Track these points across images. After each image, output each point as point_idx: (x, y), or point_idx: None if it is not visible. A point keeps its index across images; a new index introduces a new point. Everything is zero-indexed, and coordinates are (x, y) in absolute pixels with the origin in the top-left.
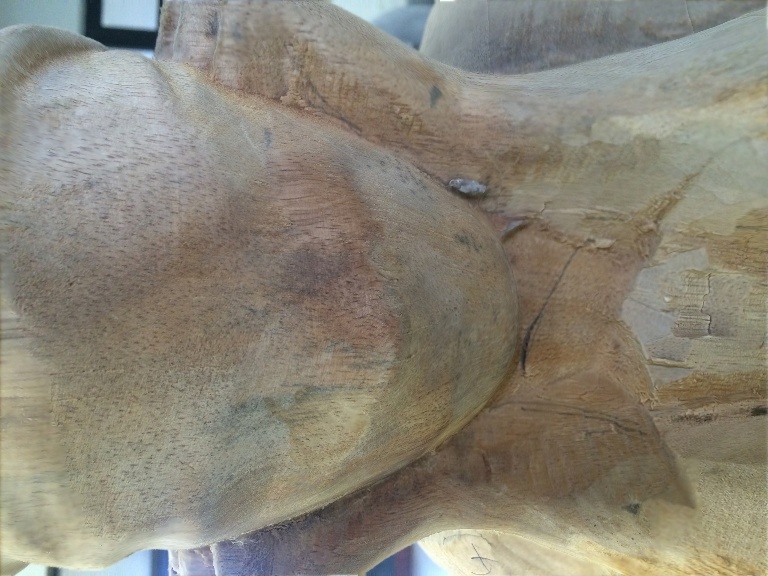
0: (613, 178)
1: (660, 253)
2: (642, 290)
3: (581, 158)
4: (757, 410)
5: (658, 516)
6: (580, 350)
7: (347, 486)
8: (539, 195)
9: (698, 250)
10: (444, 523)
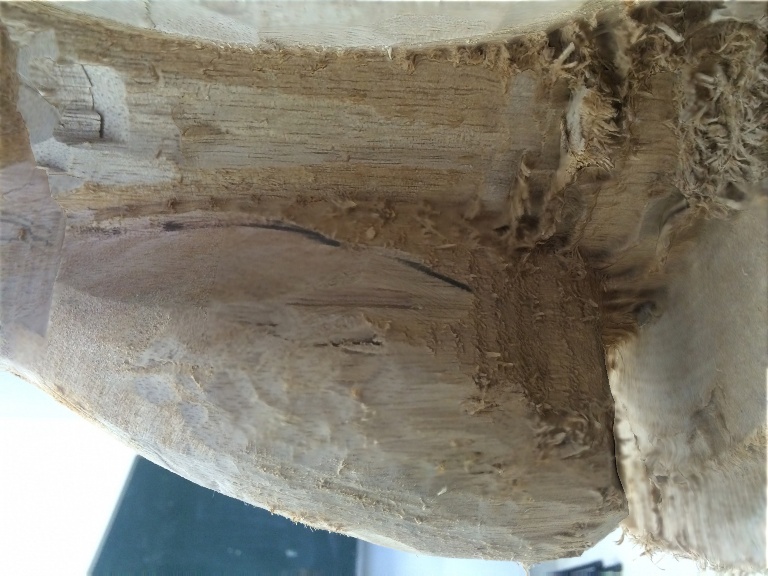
0: None
1: (13, 32)
2: (23, 77)
3: None
4: (169, 226)
5: (16, 340)
6: (1, 141)
7: None
8: None
9: (49, 32)
10: None
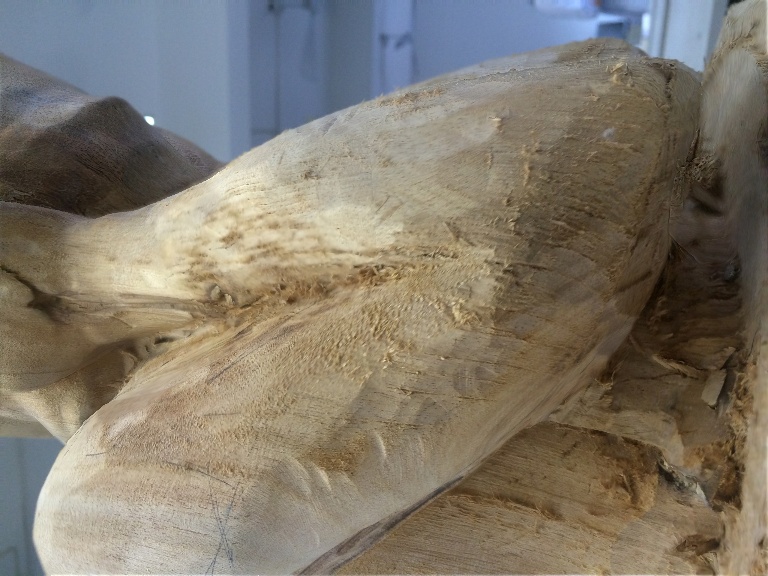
0: None
1: None
2: None
3: None
4: None
5: None
6: None
7: (37, 163)
8: None
9: None
10: (73, 230)
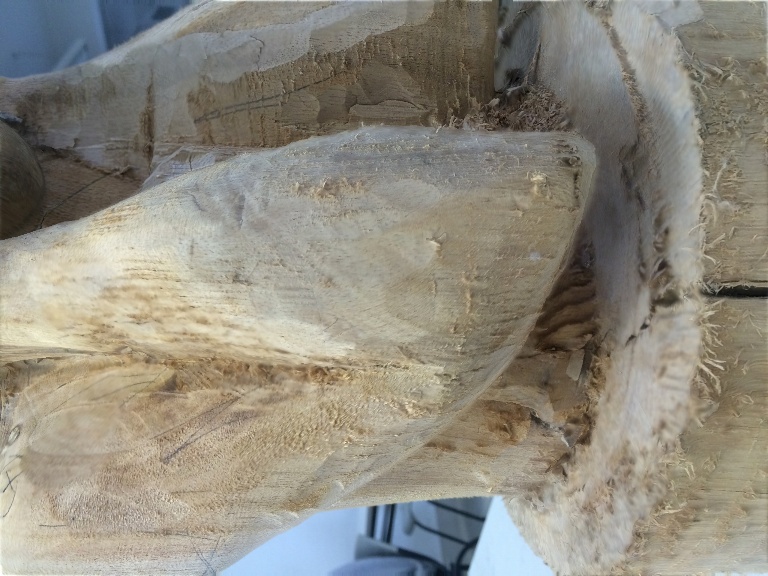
0: (108, 107)
1: (156, 157)
2: (146, 182)
3: (83, 94)
4: None
5: None
6: None
7: None
8: (69, 134)
9: None
10: None
